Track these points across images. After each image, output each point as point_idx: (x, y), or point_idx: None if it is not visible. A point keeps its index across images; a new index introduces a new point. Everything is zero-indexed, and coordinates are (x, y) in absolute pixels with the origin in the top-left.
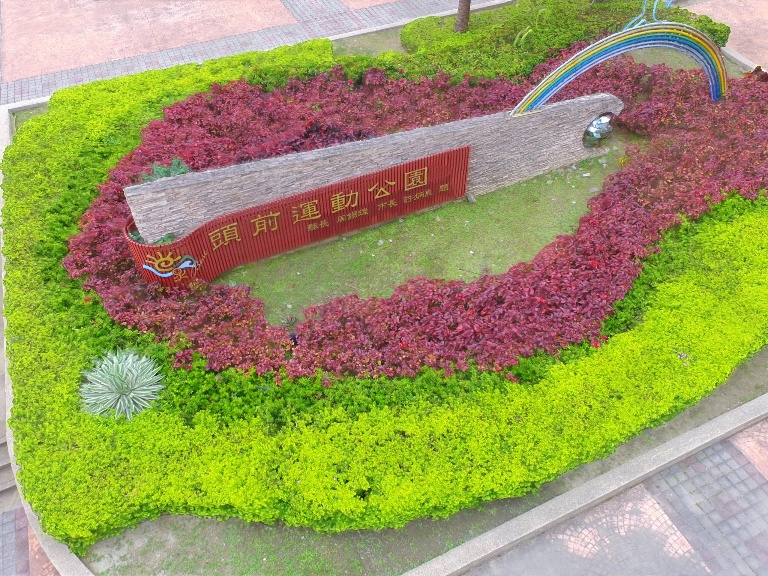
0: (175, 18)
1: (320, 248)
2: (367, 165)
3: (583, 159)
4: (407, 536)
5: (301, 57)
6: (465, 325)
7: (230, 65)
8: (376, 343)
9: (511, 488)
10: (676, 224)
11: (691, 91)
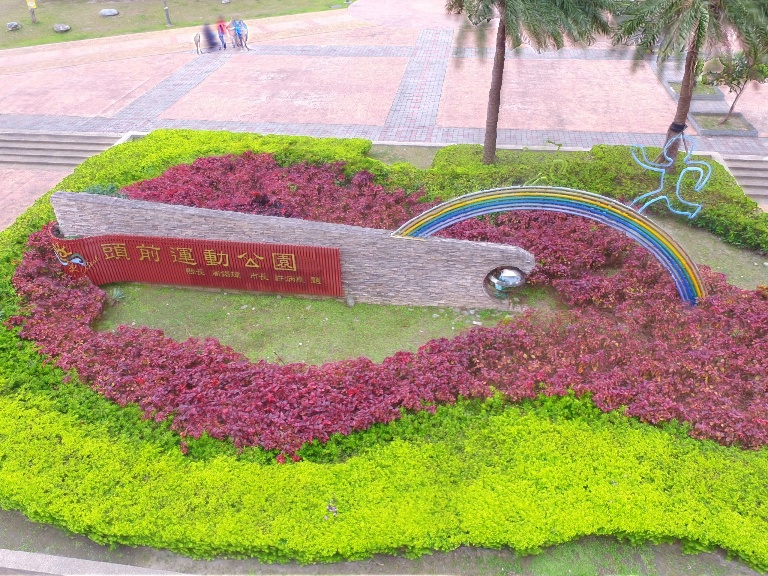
0: (304, 102)
1: (202, 293)
2: (240, 234)
3: (489, 308)
4: (10, 522)
5: (333, 149)
6: (198, 388)
7: (280, 141)
8: (130, 370)
9: (79, 525)
10: (483, 396)
11: (658, 281)
